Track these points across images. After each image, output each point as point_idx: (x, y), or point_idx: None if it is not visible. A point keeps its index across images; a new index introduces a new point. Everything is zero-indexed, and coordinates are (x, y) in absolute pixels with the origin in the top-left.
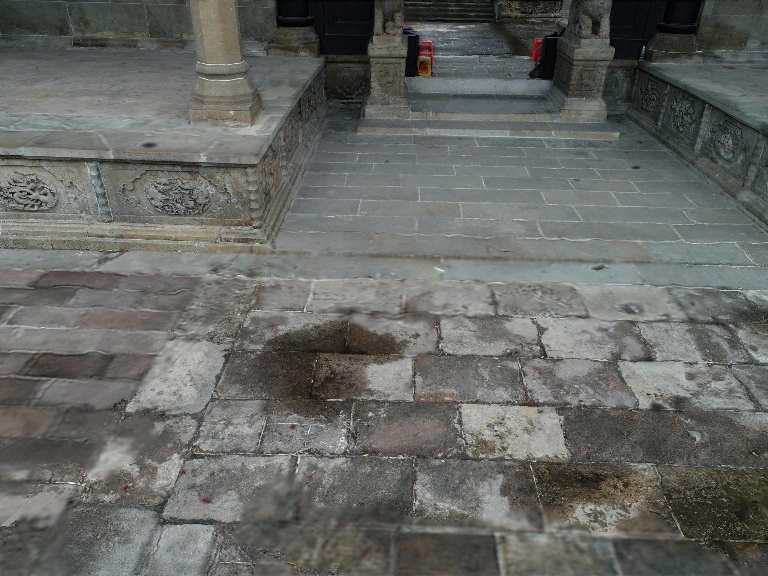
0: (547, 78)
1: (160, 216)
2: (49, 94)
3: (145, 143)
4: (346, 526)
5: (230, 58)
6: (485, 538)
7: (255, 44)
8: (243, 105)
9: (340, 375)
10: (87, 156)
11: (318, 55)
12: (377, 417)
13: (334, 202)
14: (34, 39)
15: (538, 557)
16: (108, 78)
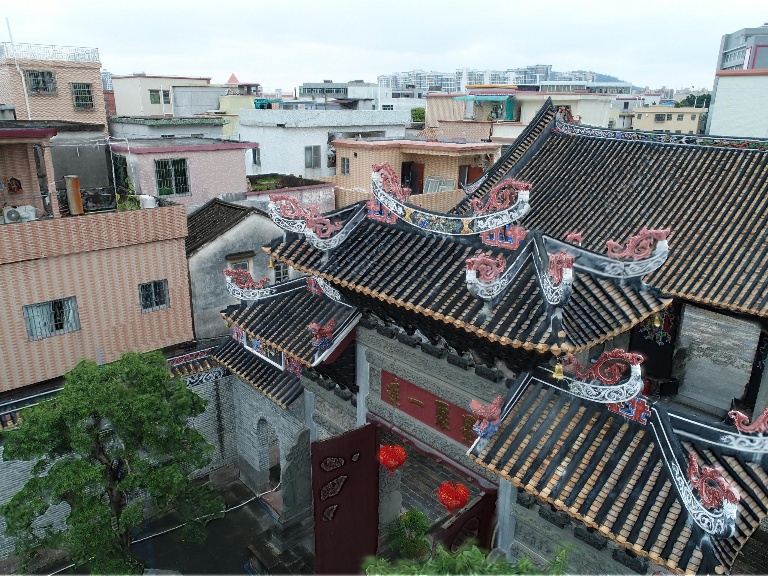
0: None
1: None
2: None
3: None
4: None
5: None
6: None
7: None
8: None
9: None
10: None
11: None
12: None
13: None
14: None
15: None
16: None
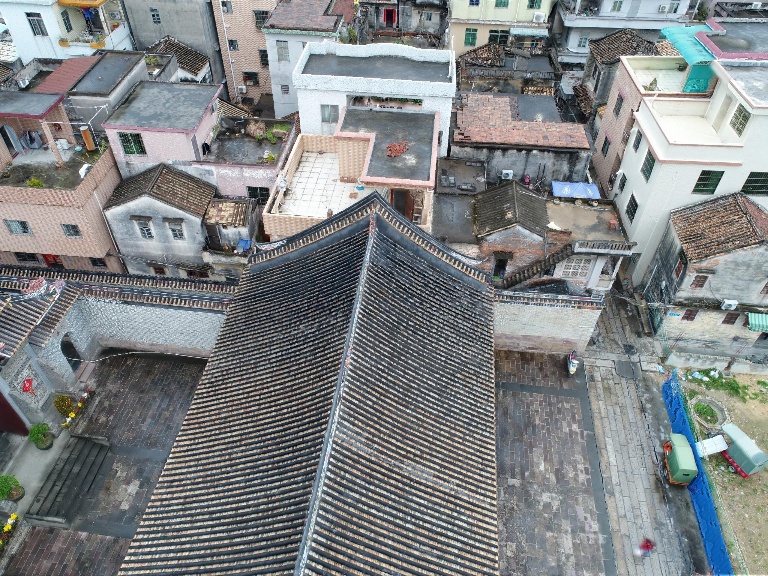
0: None
1: None
2: None
3: None
4: (528, 573)
5: None
6: (528, 557)
7: None
8: None
9: (502, 573)
10: None
11: None
12: (510, 568)
13: None
14: None
15: (531, 552)
16: None
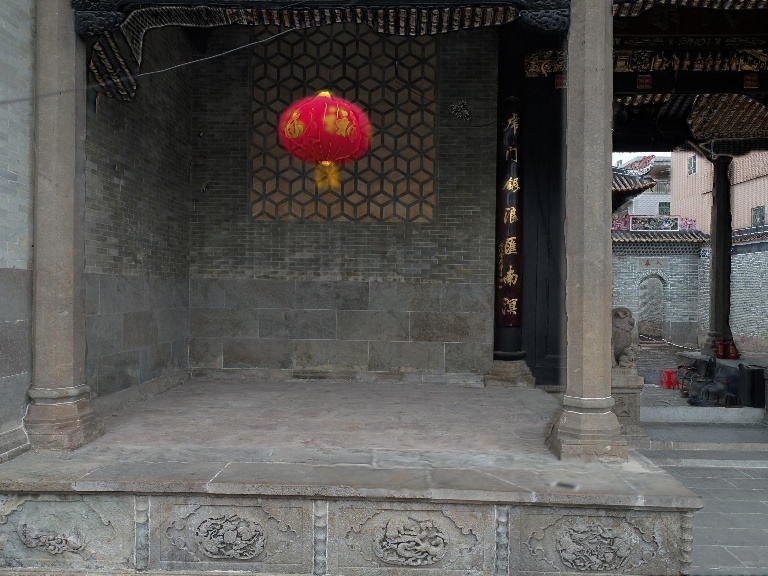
0: (759, 406)
1: (567, 572)
2: (352, 427)
3: (556, 483)
4: None
5: (605, 392)
6: None
7: (471, 376)
8: (618, 439)
9: None
10: (505, 499)
11: (534, 386)
12: None
13: (697, 549)
14: (255, 372)
15: None
16: (379, 410)
